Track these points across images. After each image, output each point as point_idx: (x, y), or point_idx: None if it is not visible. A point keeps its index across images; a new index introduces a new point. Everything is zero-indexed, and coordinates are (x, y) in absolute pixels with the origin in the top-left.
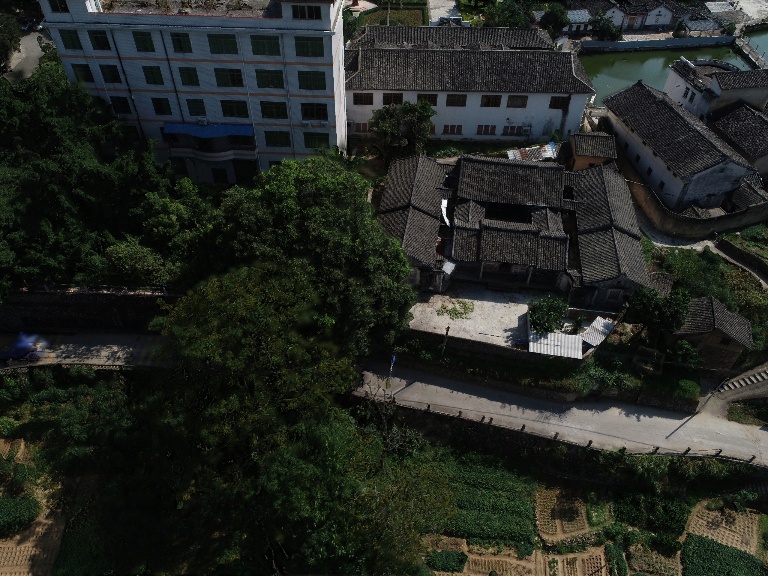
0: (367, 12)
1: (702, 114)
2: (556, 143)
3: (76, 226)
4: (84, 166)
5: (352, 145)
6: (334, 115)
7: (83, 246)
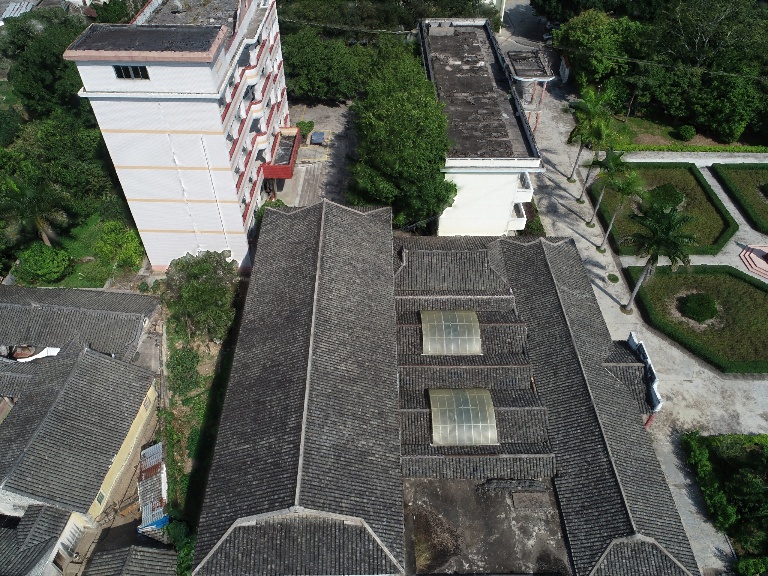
0: (738, 274)
1: None
2: (165, 530)
3: (38, 92)
4: (69, 65)
5: None
6: (123, 186)
7: (41, 108)
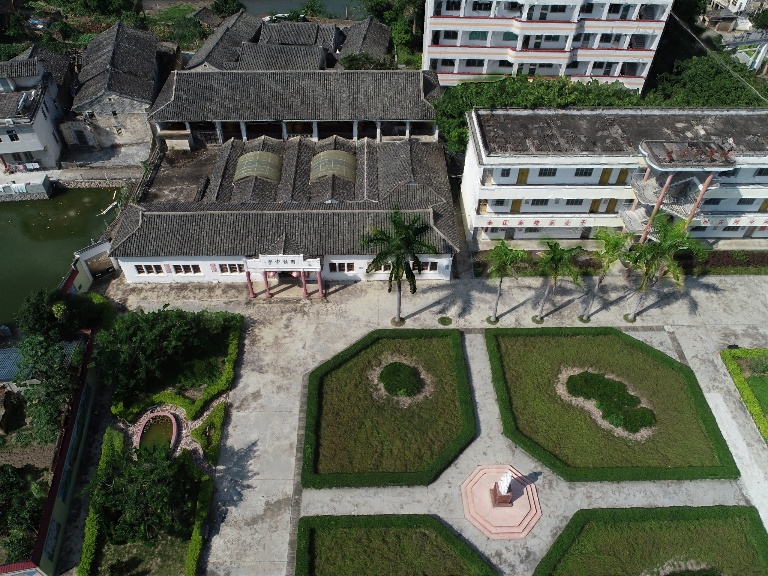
0: (459, 437)
1: None
2: None
3: None
4: None
5: None
6: None
7: None
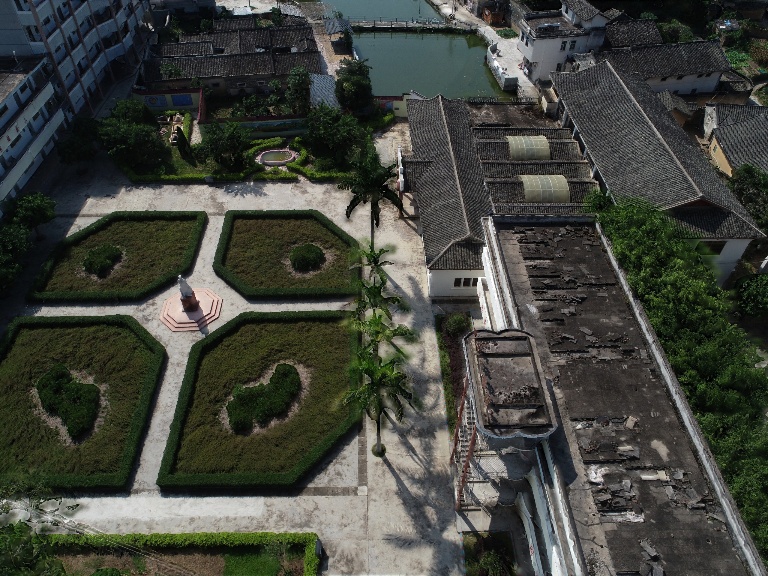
0: (245, 284)
1: (591, 49)
2: None
3: None
4: None
5: (732, 285)
6: None
7: None
